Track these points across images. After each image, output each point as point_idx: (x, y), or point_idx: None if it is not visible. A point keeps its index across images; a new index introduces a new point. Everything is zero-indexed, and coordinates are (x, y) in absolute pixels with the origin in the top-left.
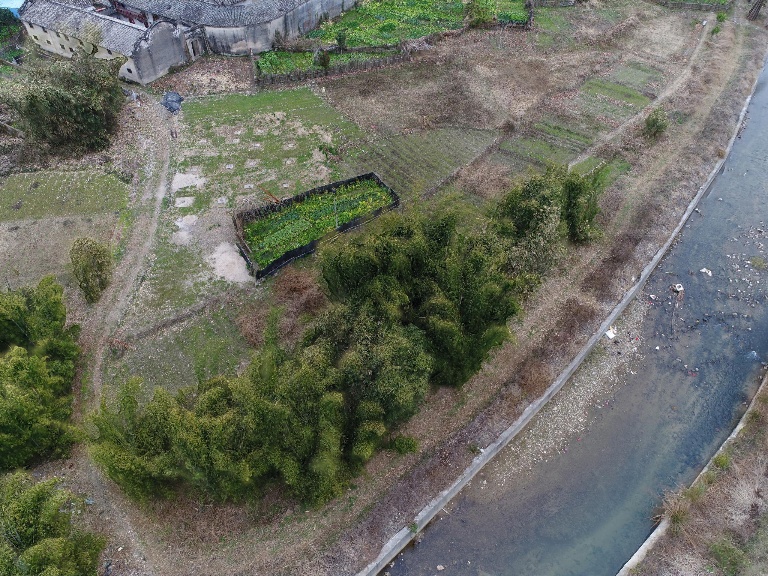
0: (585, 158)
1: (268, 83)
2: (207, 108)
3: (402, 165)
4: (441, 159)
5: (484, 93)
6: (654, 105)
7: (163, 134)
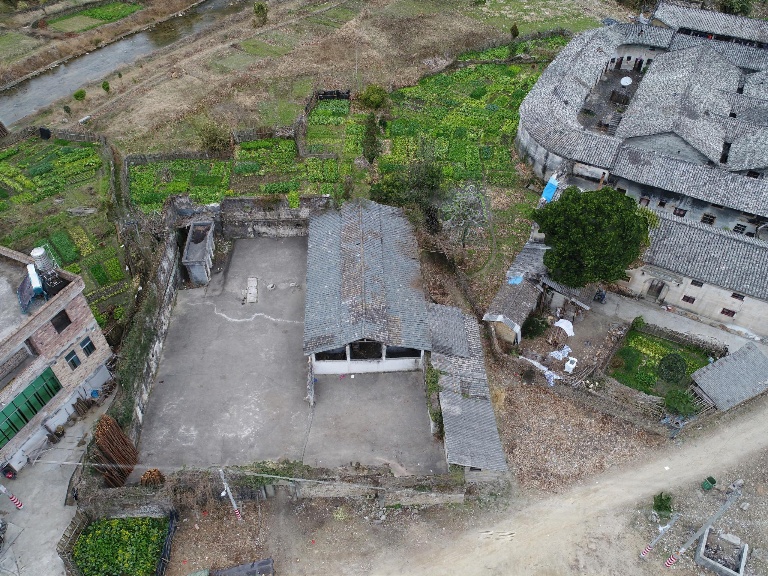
0: (316, 11)
1: (555, 36)
2: (584, 24)
3: (433, 1)
4: (409, 4)
5: (377, 38)
6: (241, 39)
7: (593, 8)
